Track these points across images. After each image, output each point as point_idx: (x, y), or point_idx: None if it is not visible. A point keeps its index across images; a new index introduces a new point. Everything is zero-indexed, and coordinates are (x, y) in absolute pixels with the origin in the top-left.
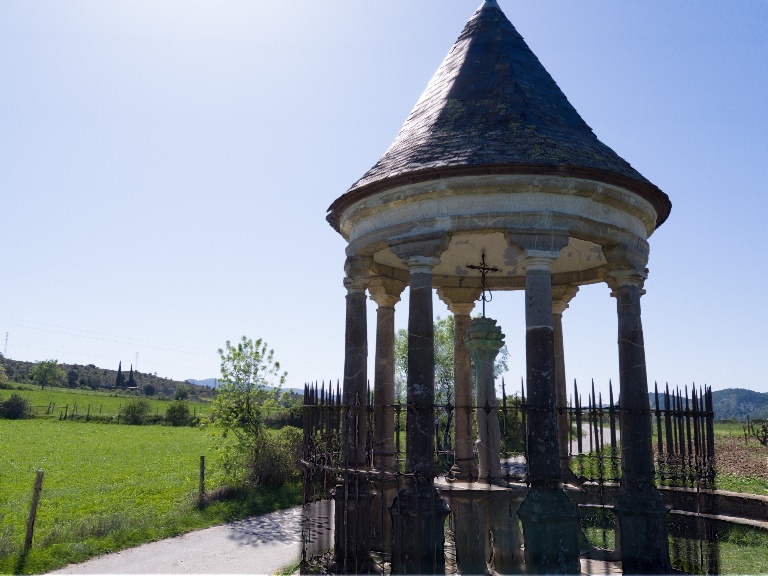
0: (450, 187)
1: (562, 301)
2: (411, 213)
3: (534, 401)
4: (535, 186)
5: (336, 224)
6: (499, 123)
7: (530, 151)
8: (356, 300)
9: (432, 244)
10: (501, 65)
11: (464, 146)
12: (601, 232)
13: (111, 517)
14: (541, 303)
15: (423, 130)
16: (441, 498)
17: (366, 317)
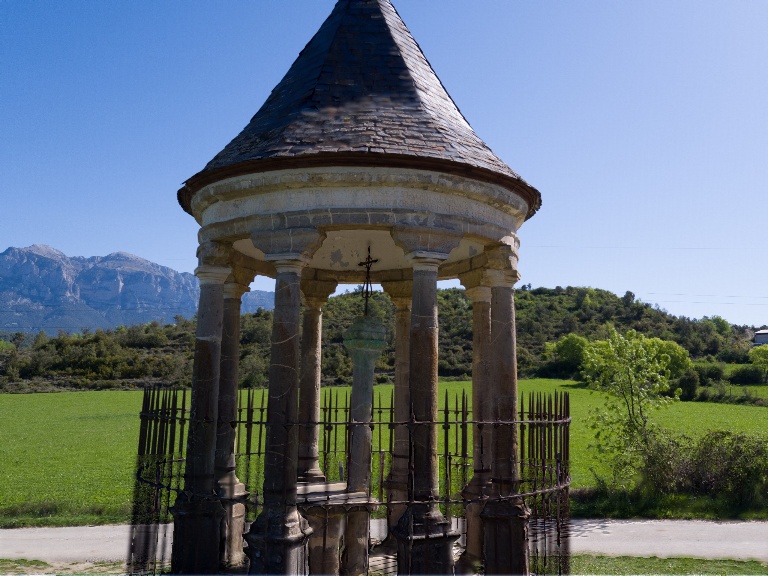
0: None
1: (492, 269)
2: None
3: None
4: (196, 210)
5: None
6: None
7: None
8: None
9: None
10: None
11: None
12: None
13: (454, 494)
14: None
15: None
16: (220, 487)
17: (314, 330)
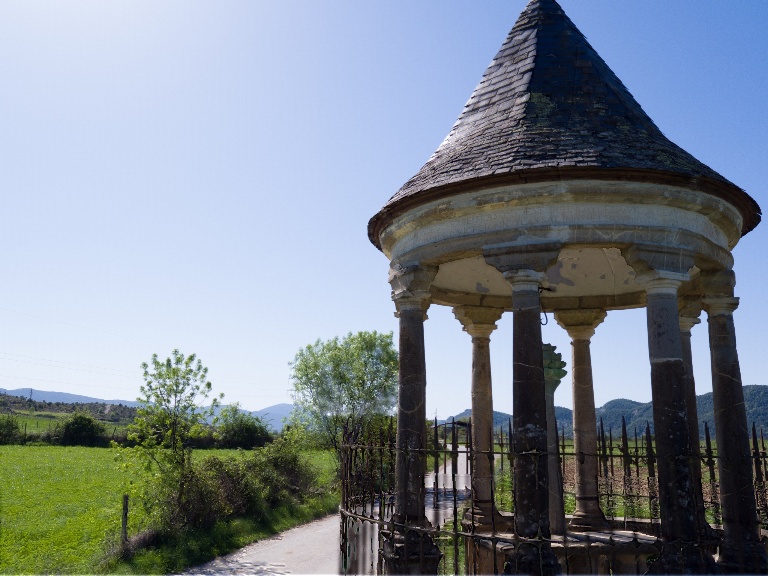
0: (572, 191)
1: (592, 326)
2: (514, 219)
3: (670, 446)
4: (665, 198)
5: (375, 226)
6: (605, 124)
7: (659, 158)
8: (414, 318)
9: (546, 257)
10: (582, 62)
11: (581, 145)
12: (715, 255)
13: None
14: (673, 332)
15: (508, 124)
16: (559, 563)
17: None
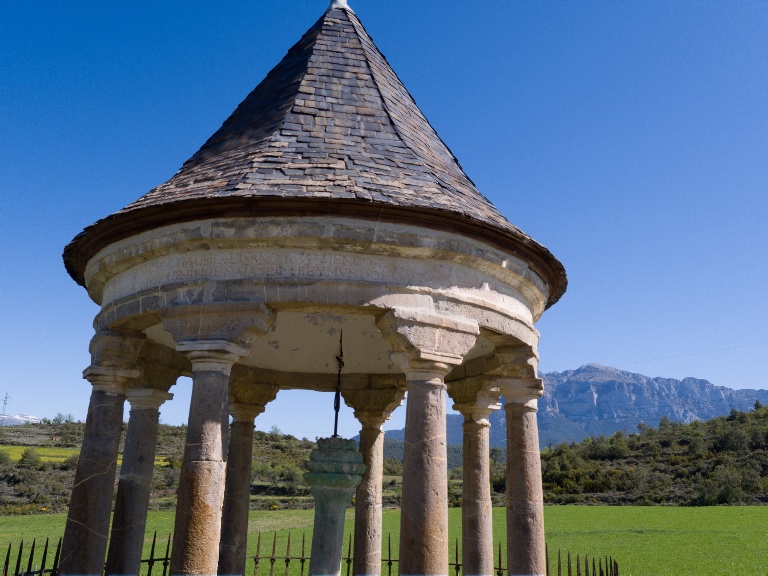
0: None
1: (397, 353)
2: None
3: None
4: None
5: None
6: None
7: None
8: None
9: None
10: None
11: None
12: None
13: None
14: None
15: None
16: None
17: (367, 455)
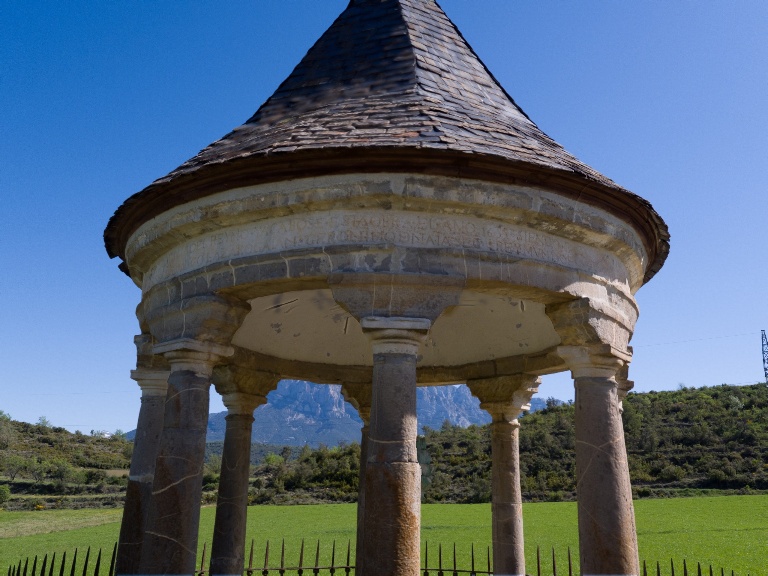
0: None
1: (566, 346)
2: None
3: None
4: None
5: None
6: None
7: None
8: None
9: None
10: None
11: None
12: None
13: None
14: None
15: None
16: None
17: None
